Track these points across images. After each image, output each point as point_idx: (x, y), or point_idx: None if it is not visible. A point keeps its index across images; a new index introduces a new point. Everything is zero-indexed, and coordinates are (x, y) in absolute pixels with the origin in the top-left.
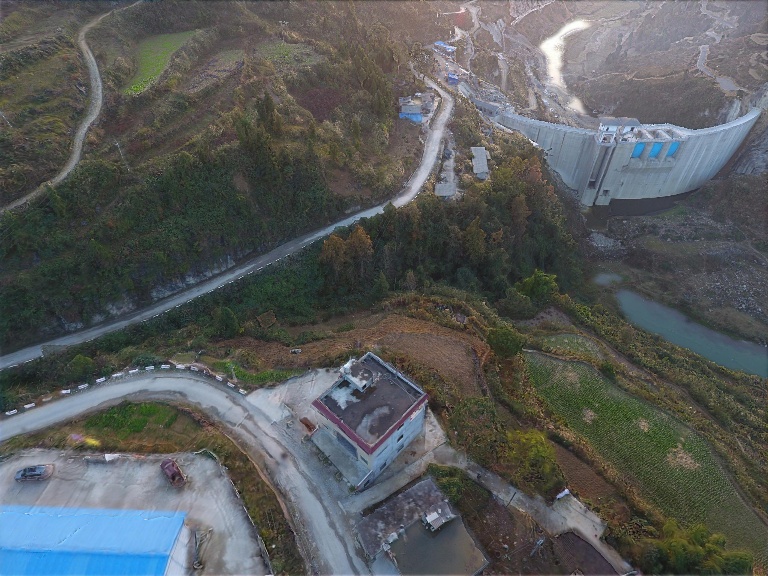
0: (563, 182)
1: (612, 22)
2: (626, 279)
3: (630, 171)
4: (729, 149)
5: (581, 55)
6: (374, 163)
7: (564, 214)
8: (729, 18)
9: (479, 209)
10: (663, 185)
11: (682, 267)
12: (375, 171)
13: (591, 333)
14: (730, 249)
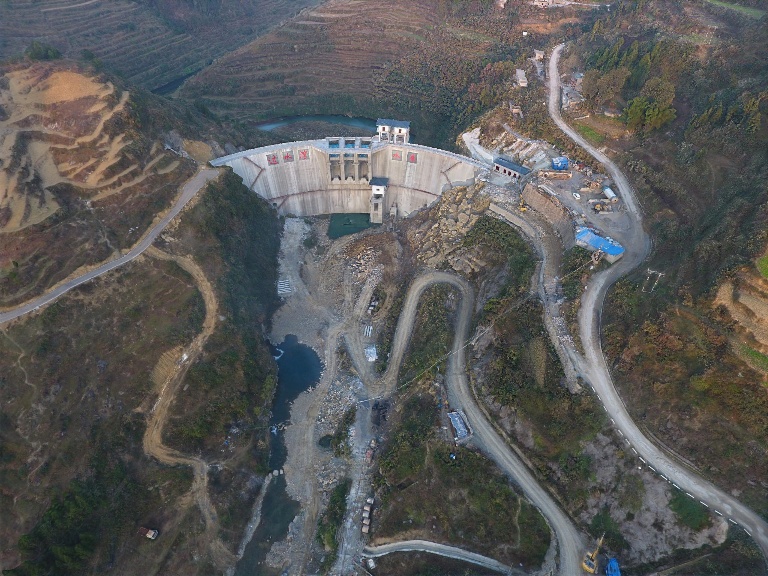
0: None
1: None
2: None
3: None
4: None
5: None
6: None
7: None
8: None
9: None
10: None
11: None
12: None
13: None
14: None
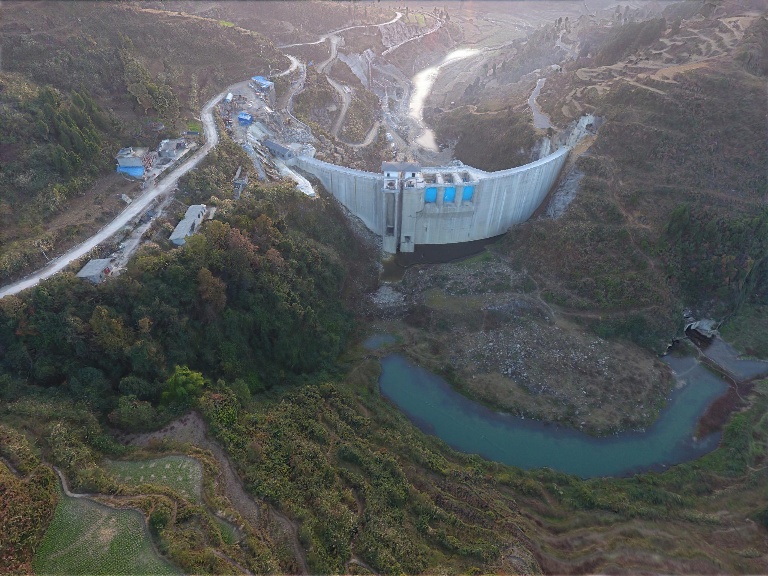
0: (367, 228)
1: (492, 51)
2: (399, 341)
3: (430, 216)
4: (537, 190)
5: (448, 85)
6: (7, 238)
7: (350, 267)
8: (579, 50)
9: (128, 291)
10: (471, 229)
11: (459, 325)
12: (0, 249)
13: (219, 448)
14: (515, 302)
